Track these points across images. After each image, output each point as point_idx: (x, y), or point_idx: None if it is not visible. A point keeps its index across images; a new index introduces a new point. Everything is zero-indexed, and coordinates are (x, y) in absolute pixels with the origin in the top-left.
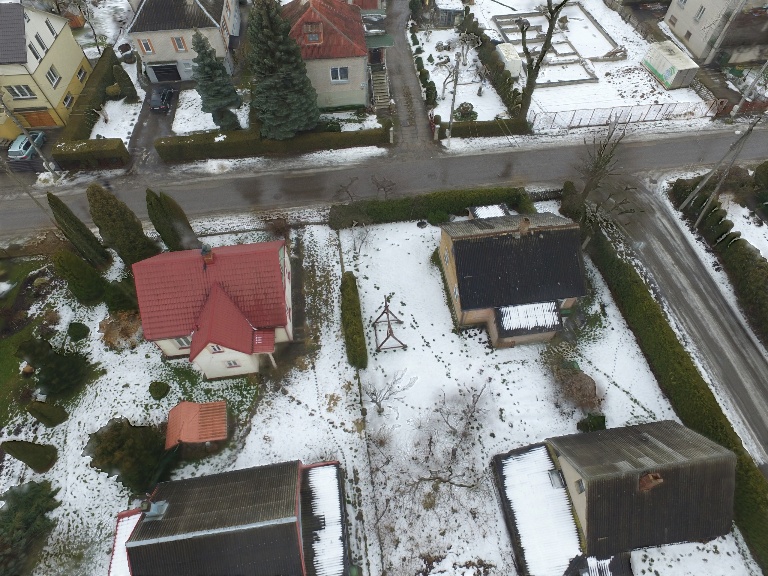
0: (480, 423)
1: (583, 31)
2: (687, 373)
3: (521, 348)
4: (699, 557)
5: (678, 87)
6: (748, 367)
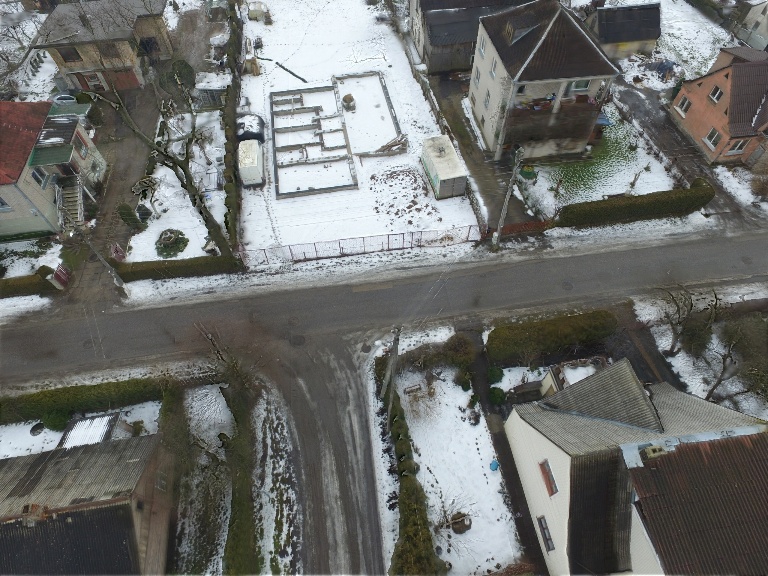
0: None
1: (371, 112)
2: None
3: None
4: None
5: (450, 196)
6: None
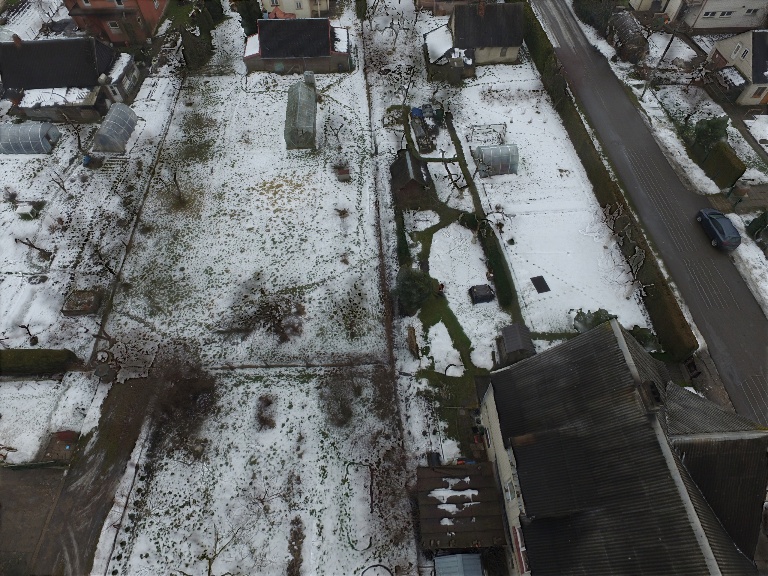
0: (421, 35)
1: None
2: (524, 6)
3: (449, 16)
4: (512, 69)
5: None
6: (566, 23)
